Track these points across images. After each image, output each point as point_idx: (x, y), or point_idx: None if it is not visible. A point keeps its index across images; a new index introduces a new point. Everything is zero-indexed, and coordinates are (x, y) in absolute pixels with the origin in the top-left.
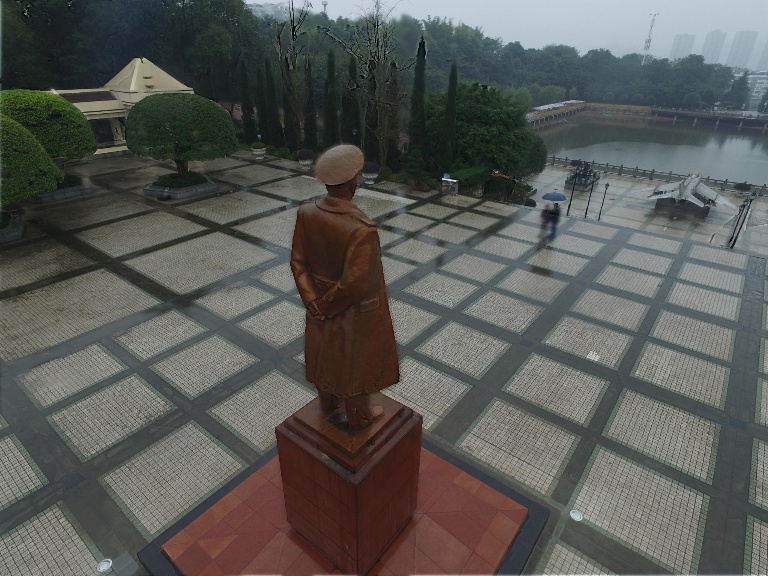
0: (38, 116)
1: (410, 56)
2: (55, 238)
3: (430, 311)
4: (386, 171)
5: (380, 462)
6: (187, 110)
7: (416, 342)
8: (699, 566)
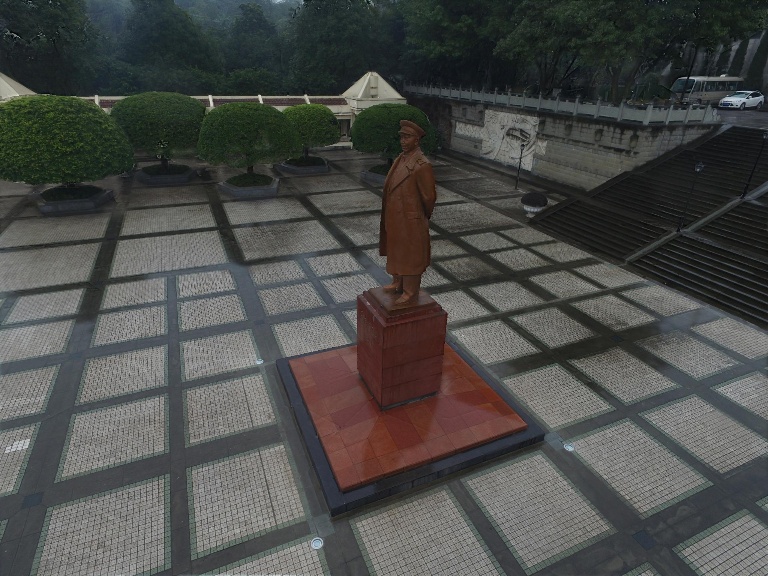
0: None
1: None
2: None
3: None
4: None
5: None
6: None
7: None
8: None
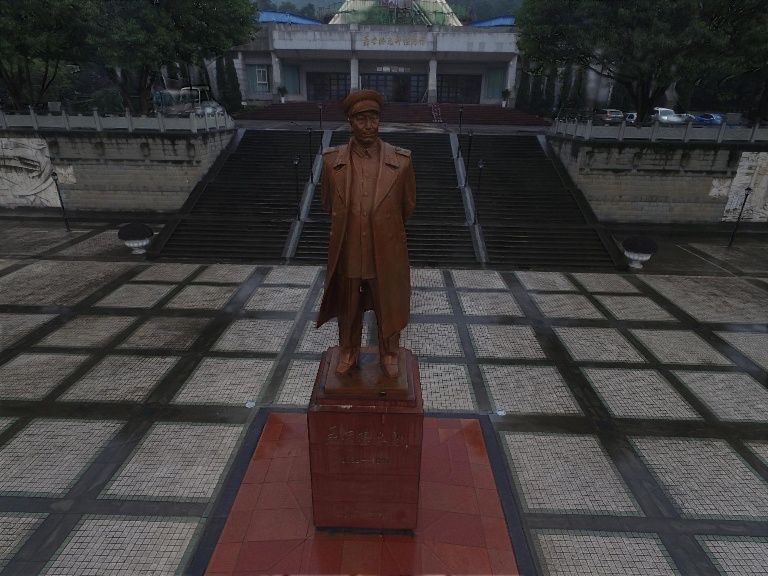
0: None
1: None
2: None
3: None
4: None
5: None
6: None
7: None
8: None
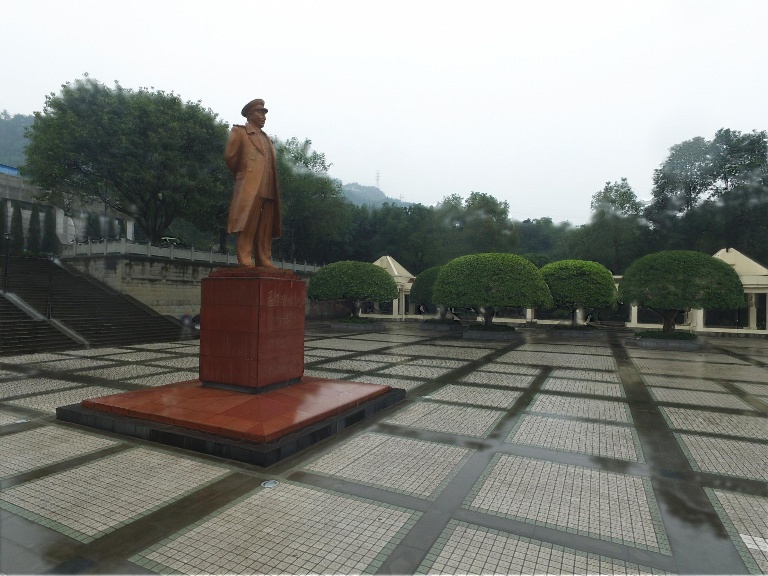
0: (569, 273)
1: None
2: (515, 342)
3: (635, 418)
4: None
5: (219, 280)
6: (667, 260)
7: (542, 414)
8: (156, 572)
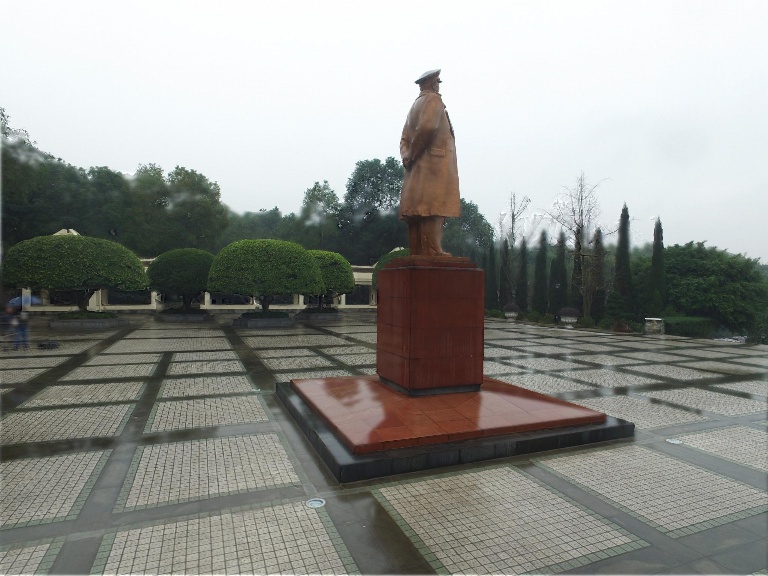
0: (325, 262)
1: (613, 220)
2: (308, 327)
3: (583, 364)
4: (588, 320)
5: (436, 270)
6: None
7: (555, 371)
8: None
